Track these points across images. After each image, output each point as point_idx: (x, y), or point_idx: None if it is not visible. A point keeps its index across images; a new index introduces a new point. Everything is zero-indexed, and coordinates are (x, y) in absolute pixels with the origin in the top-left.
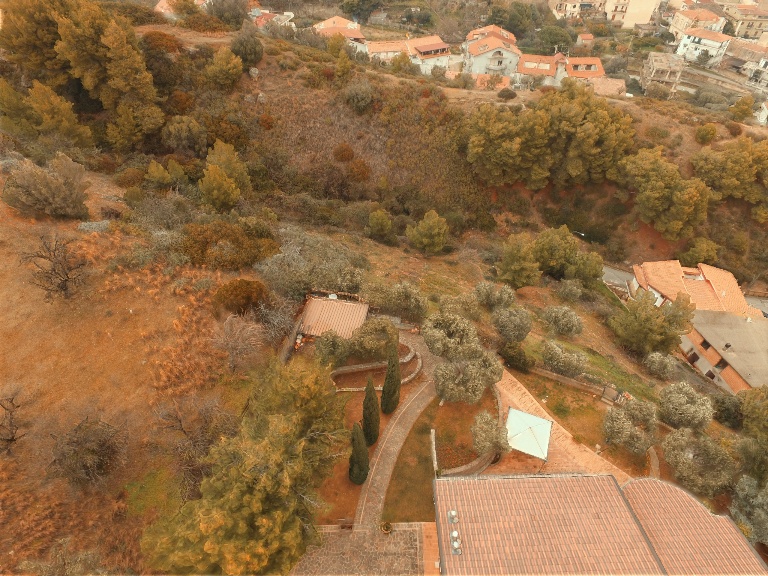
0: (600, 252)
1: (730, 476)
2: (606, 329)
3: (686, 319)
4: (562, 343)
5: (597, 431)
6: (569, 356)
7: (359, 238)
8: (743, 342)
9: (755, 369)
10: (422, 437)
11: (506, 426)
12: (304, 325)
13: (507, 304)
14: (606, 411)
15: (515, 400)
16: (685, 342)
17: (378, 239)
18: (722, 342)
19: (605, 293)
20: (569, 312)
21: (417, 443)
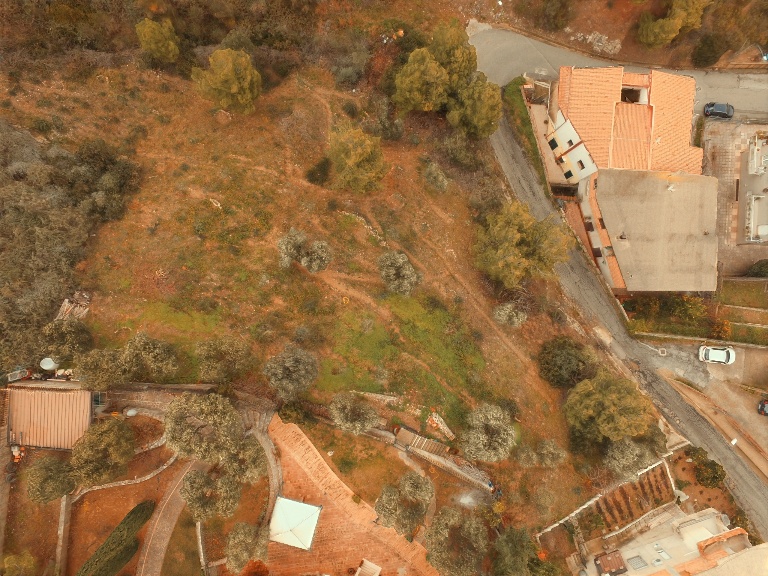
0: (532, 13)
1: (474, 572)
2: (476, 228)
3: (558, 258)
4: (394, 304)
5: (381, 484)
6: (351, 427)
7: (136, 72)
8: (647, 224)
9: (642, 265)
10: (188, 531)
11: (271, 519)
12: (14, 433)
13: (320, 269)
14: (396, 458)
15: (297, 458)
16: (586, 207)
17: (168, 67)
18: (621, 225)
19: (516, 108)
20: (406, 265)
21: (183, 538)
